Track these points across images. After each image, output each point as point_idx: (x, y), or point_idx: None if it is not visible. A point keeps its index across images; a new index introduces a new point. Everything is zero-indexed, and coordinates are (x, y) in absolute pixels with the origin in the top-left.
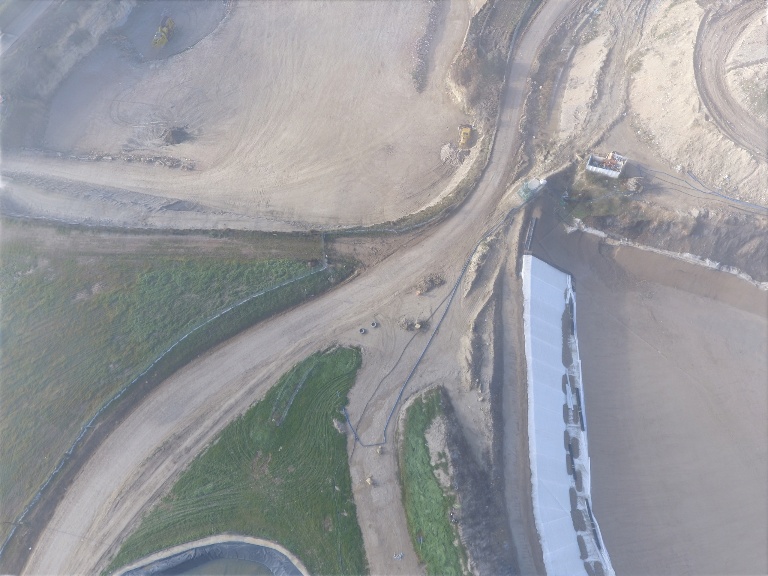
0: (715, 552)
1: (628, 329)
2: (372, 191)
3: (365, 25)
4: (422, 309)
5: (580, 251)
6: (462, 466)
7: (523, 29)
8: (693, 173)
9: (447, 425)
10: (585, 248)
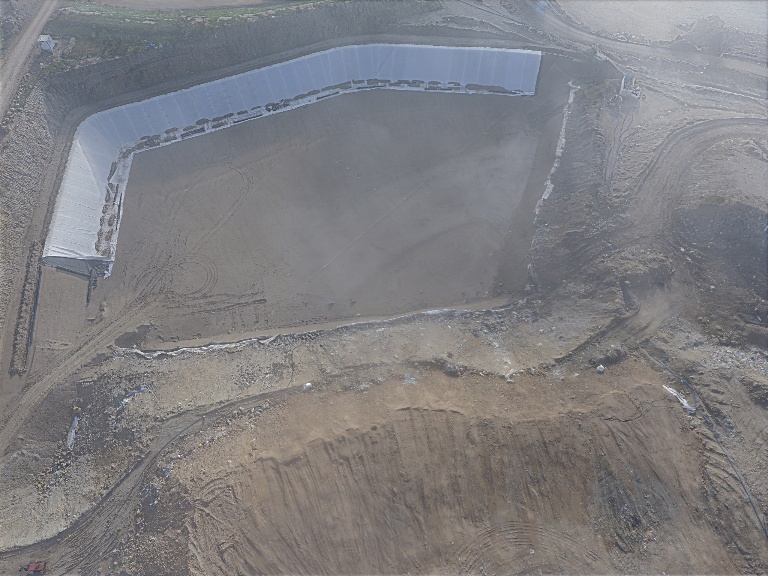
0: (359, 137)
1: (498, 119)
2: (577, 2)
3: (739, 1)
4: (491, 3)
5: (555, 98)
6: (399, 6)
7: (764, 64)
8: (637, 133)
9: (421, 3)
10: (558, 100)
